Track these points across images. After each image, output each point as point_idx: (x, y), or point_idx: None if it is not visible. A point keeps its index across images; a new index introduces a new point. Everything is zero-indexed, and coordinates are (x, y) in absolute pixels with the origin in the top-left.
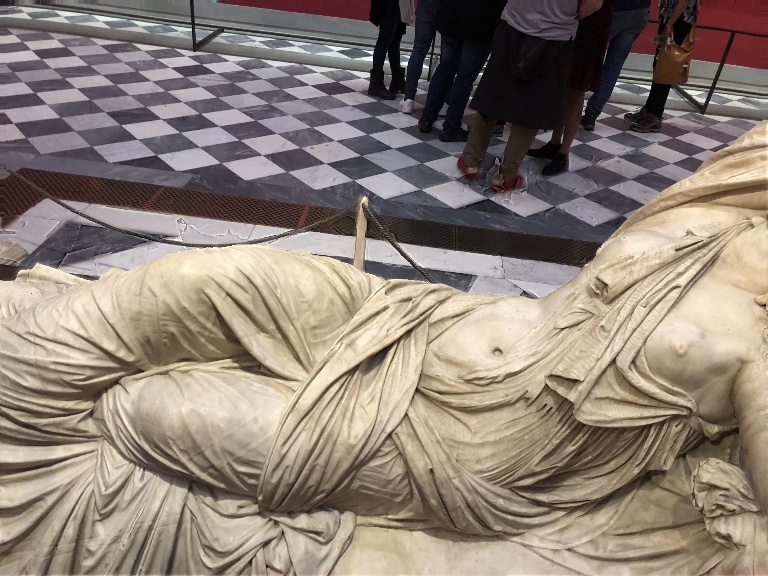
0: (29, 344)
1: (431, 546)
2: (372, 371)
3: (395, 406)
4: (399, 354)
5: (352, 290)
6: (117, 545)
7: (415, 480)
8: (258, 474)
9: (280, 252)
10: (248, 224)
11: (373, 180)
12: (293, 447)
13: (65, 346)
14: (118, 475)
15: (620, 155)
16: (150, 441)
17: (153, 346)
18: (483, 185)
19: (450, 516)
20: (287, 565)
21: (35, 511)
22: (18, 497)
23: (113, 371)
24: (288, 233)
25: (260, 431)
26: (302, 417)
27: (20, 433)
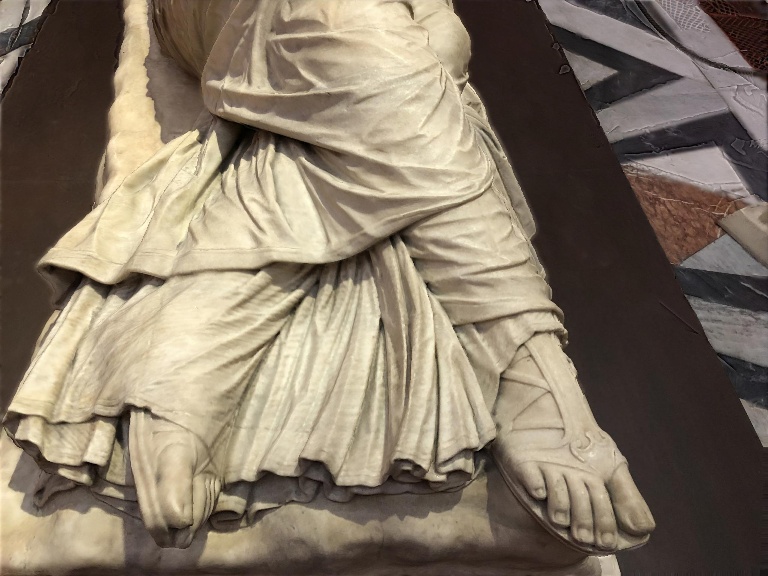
0: None
1: None
2: None
3: None
4: None
5: None
6: None
7: None
8: None
9: None
10: None
11: None
12: None
13: None
14: None
15: None
16: None
17: None
18: None
19: None
20: None
21: None
22: None
23: None
24: None
25: None
26: None
27: None
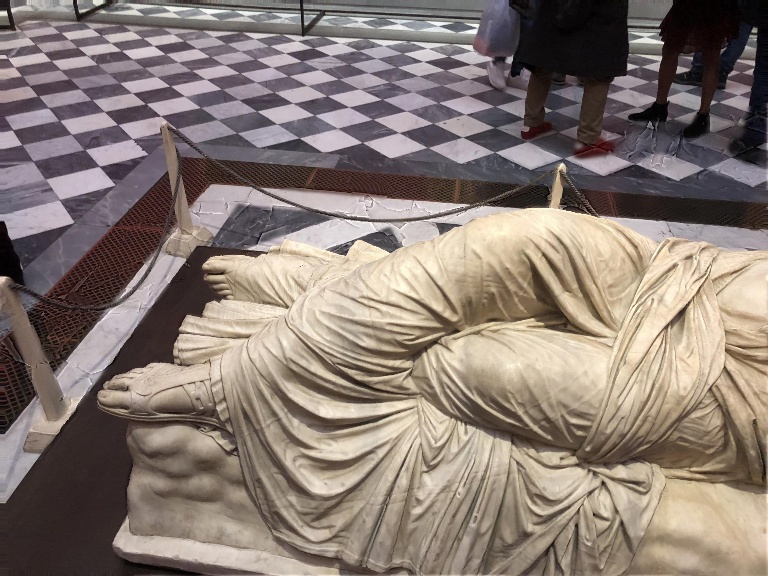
0: (364, 307)
1: (737, 497)
2: (674, 327)
3: (712, 359)
4: (697, 310)
5: (640, 249)
6: (445, 494)
7: (734, 431)
8: (588, 426)
9: (571, 214)
10: (406, 200)
11: (513, 152)
12: (627, 399)
13: (398, 308)
14: (443, 429)
15: (761, 113)
16: (486, 395)
17: (472, 307)
18: (633, 150)
19: (765, 467)
20: (612, 513)
21: (367, 463)
22: (350, 450)
23: (436, 331)
24: (478, 204)
25: (591, 384)
26: (634, 370)
27: (353, 391)
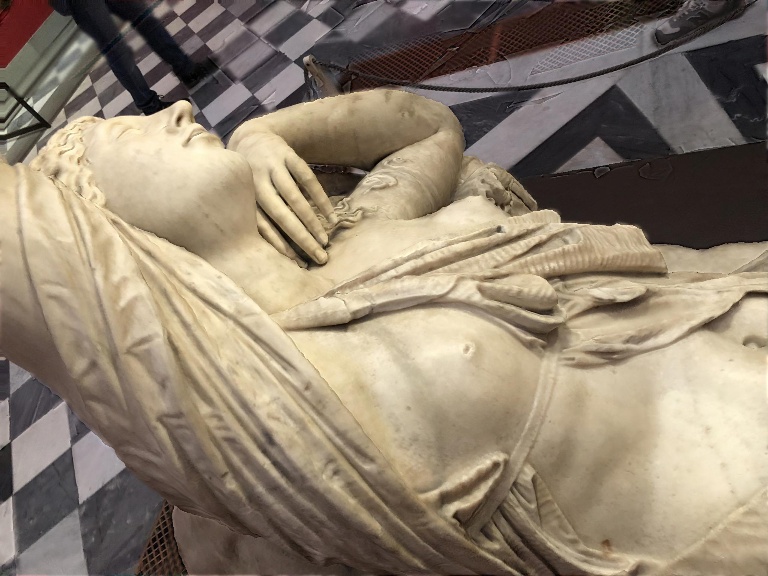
0: None
1: None
2: None
3: None
4: None
5: None
6: None
7: None
8: None
9: None
10: None
11: None
12: None
13: None
14: None
15: None
16: None
17: None
18: None
19: None
20: None
21: None
22: None
23: None
24: None
25: None
26: None
27: None
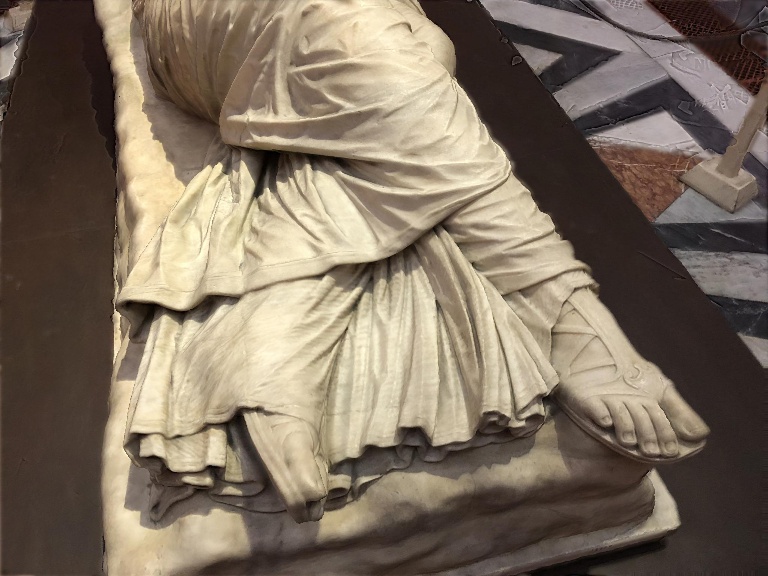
0: None
1: None
2: None
3: None
4: None
5: None
6: None
7: None
8: None
9: None
10: None
11: None
12: None
13: None
14: None
15: None
16: None
17: None
18: None
19: None
20: None
21: None
22: None
23: None
24: None
25: None
26: None
27: None
